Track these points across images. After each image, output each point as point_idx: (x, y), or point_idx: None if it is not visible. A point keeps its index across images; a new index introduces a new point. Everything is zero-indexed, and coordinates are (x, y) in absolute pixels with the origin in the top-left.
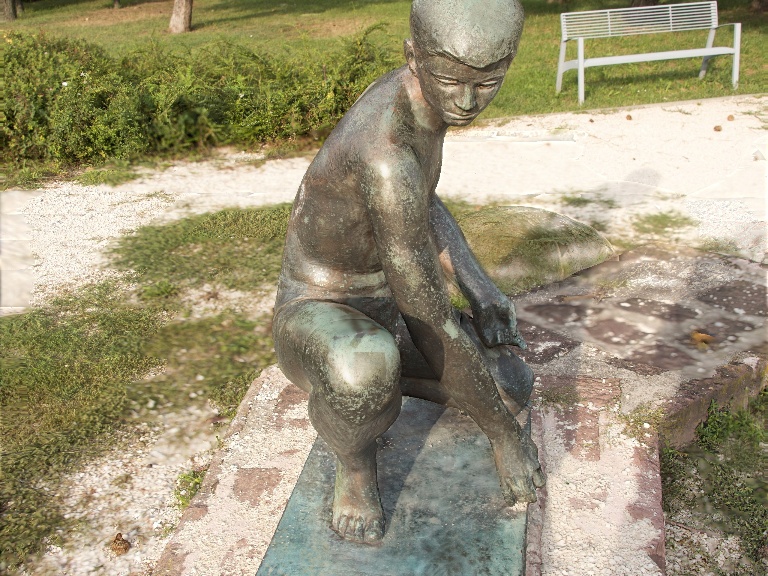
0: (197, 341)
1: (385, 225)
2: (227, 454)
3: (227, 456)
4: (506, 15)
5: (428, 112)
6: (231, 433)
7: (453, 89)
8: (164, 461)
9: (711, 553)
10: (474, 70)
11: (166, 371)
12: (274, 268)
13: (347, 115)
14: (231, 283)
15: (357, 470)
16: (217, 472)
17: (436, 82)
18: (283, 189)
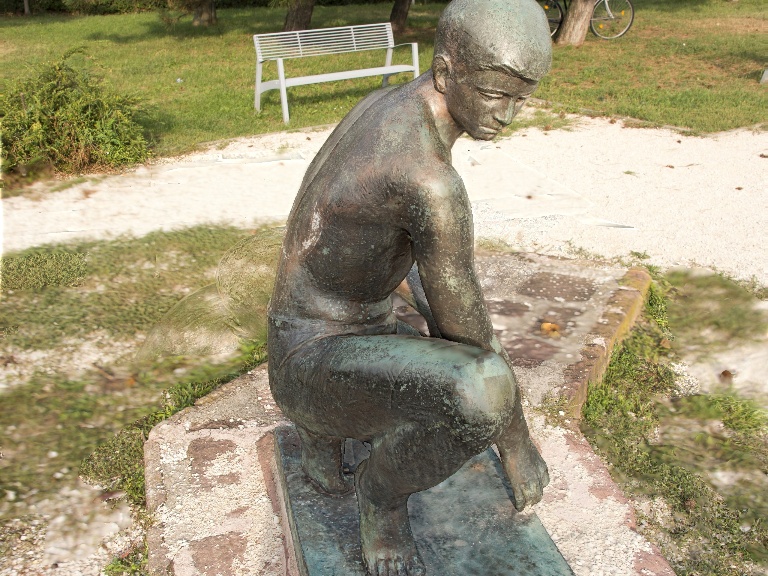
0: (23, 414)
1: (441, 246)
2: (164, 530)
3: (166, 532)
4: (548, 29)
5: (450, 128)
6: (155, 506)
7: (495, 103)
8: (69, 556)
9: (649, 516)
10: (525, 83)
11: (3, 455)
12: (67, 320)
13: (371, 136)
14: (24, 343)
15: (395, 508)
16: (163, 552)
17: (480, 97)
18: (20, 232)
